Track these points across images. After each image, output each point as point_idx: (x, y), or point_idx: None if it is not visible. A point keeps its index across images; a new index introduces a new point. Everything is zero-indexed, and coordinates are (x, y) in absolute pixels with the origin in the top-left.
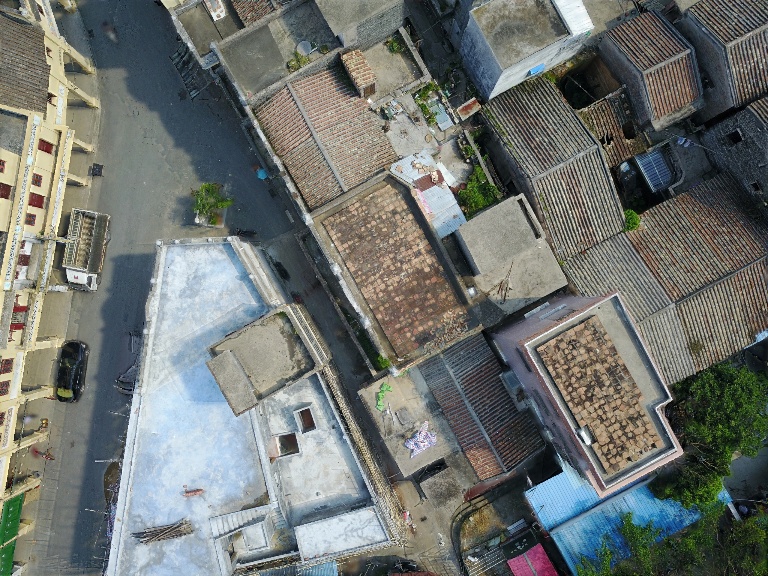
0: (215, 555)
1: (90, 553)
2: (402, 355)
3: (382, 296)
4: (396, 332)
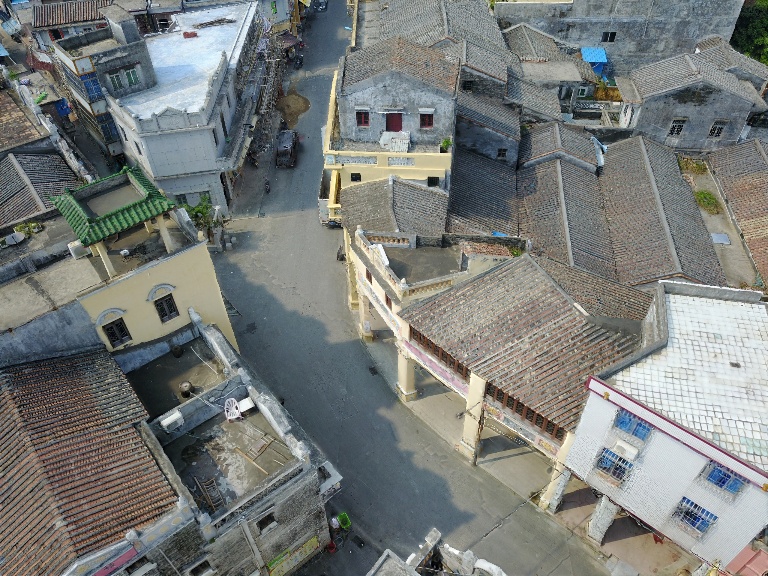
0: (179, 22)
1: (316, 81)
2: (2, 92)
3: (6, 114)
4: (2, 100)
